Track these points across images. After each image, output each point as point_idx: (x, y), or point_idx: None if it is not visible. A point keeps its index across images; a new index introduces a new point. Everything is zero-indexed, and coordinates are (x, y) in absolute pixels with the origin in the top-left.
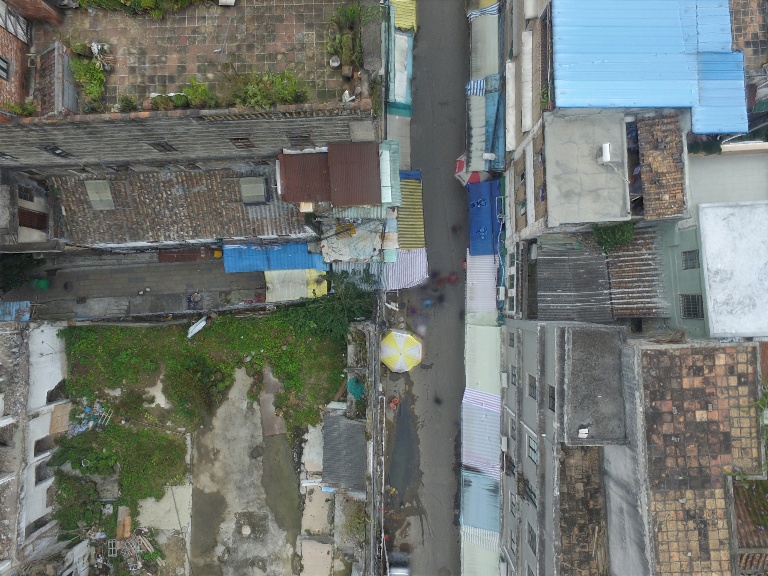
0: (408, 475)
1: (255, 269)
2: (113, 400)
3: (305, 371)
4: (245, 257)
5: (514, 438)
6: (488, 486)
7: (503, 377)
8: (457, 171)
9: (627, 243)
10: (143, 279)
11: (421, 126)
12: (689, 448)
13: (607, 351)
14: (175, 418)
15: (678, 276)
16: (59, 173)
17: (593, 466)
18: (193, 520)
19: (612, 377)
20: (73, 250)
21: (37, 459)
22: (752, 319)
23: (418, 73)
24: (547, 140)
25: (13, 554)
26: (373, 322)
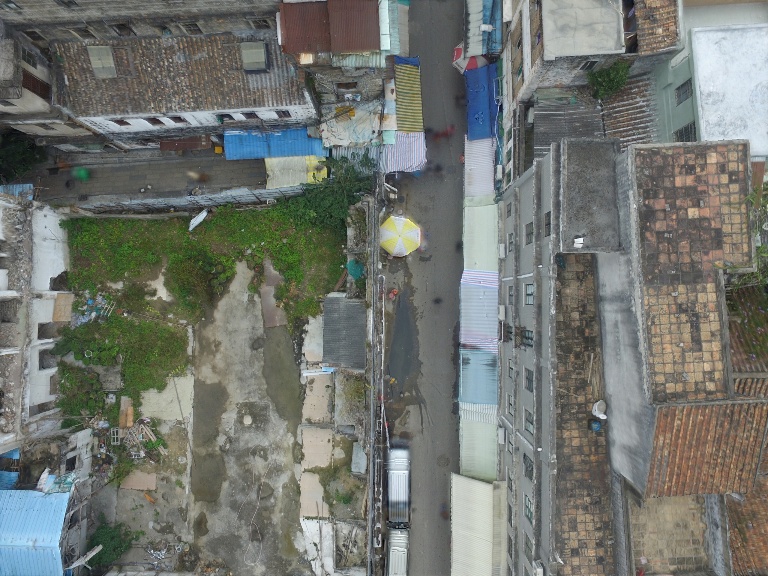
0: (407, 365)
1: (255, 156)
2: (115, 293)
3: (305, 263)
4: (246, 144)
5: (511, 303)
6: (486, 361)
7: (501, 247)
8: (455, 59)
9: (622, 93)
10: (144, 177)
11: (419, 23)
12: (681, 244)
13: (602, 164)
14: (177, 310)
15: (672, 115)
16: (62, 37)
17: (588, 295)
18: (195, 411)
19: (606, 189)
20: (75, 136)
21: (41, 342)
22: None
23: None
24: None
25: (18, 427)
26: (372, 196)
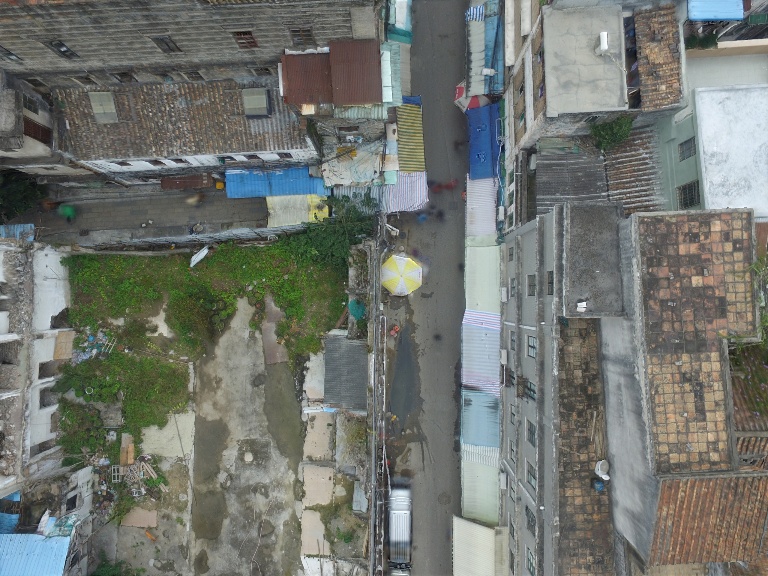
0: (409, 402)
1: (257, 195)
2: (116, 329)
3: (306, 299)
4: (247, 182)
5: (514, 348)
6: (488, 403)
7: (503, 291)
8: (457, 97)
9: (625, 144)
10: (146, 212)
11: (421, 58)
12: (685, 313)
13: (605, 227)
14: (178, 347)
15: (675, 170)
16: (63, 84)
17: (591, 353)
18: (196, 447)
19: (610, 252)
20: (76, 175)
21: (41, 382)
22: (747, 200)
23: (418, 6)
24: (546, 32)
25: (18, 470)
26: (374, 239)
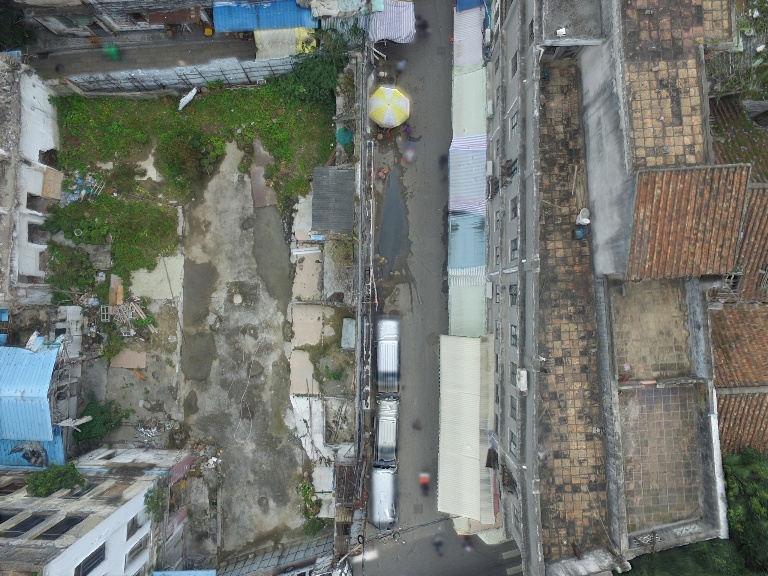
0: (397, 245)
1: (245, 29)
2: (105, 173)
3: (295, 142)
4: (235, 16)
5: None
6: (474, 224)
7: (488, 103)
8: None
9: None
10: (134, 61)
11: None
12: (662, 22)
13: None
14: (167, 191)
15: None
16: None
17: (572, 109)
18: (185, 290)
19: None
20: (64, 6)
21: (29, 212)
22: None
23: None
24: None
25: (6, 288)
26: (361, 54)
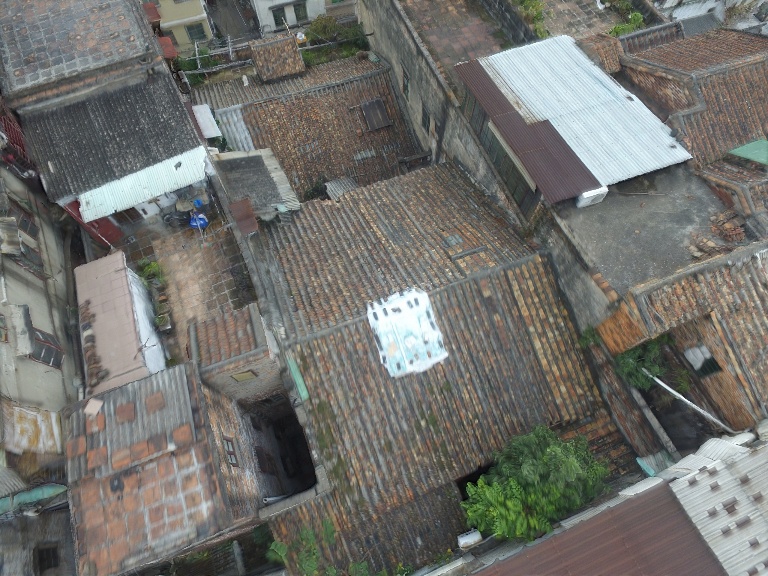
0: None
1: None
2: None
3: None
4: None
5: None
6: None
7: None
8: None
9: None
10: None
11: None
12: None
13: None
14: None
15: None
16: None
17: None
18: None
19: None
20: None
21: None
22: None
23: None
24: None
25: None
26: None
